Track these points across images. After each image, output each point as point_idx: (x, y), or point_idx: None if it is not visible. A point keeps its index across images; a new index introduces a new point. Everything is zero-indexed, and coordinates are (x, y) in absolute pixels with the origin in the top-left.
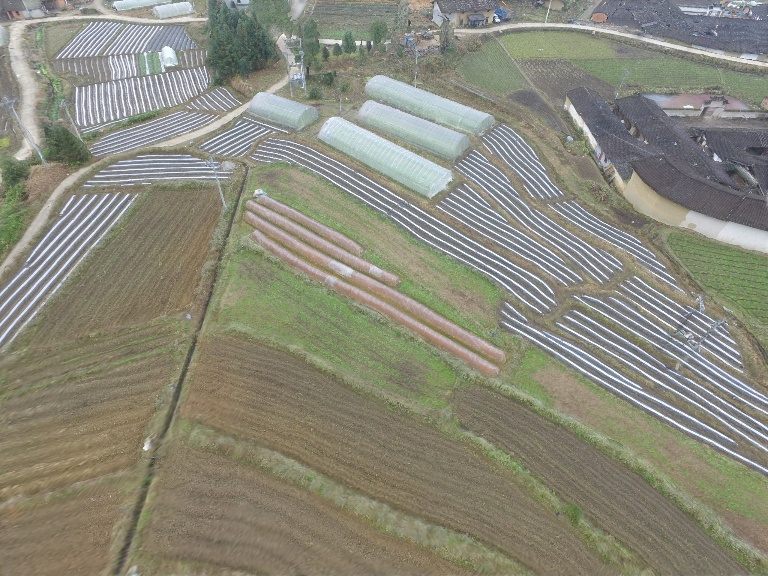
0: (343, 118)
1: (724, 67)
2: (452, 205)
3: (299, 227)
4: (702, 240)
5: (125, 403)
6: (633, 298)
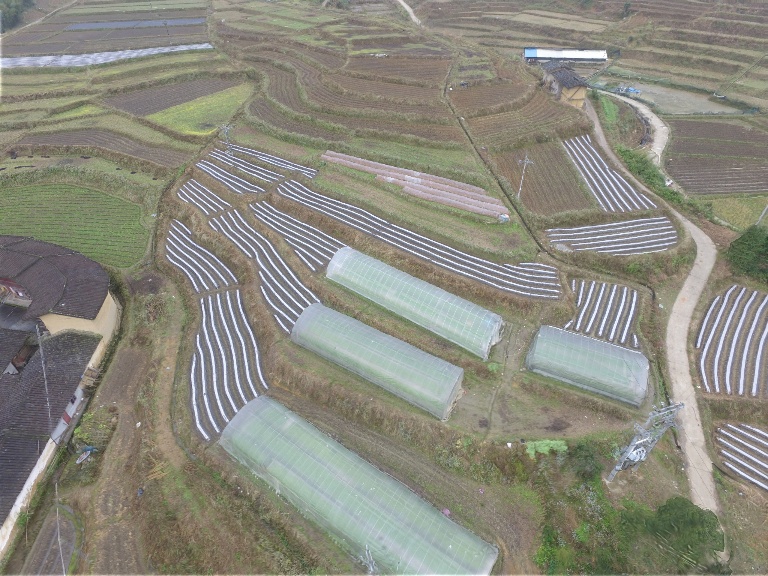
0: (492, 388)
1: None
2: (332, 249)
3: (454, 195)
4: (106, 263)
5: None
6: (220, 204)
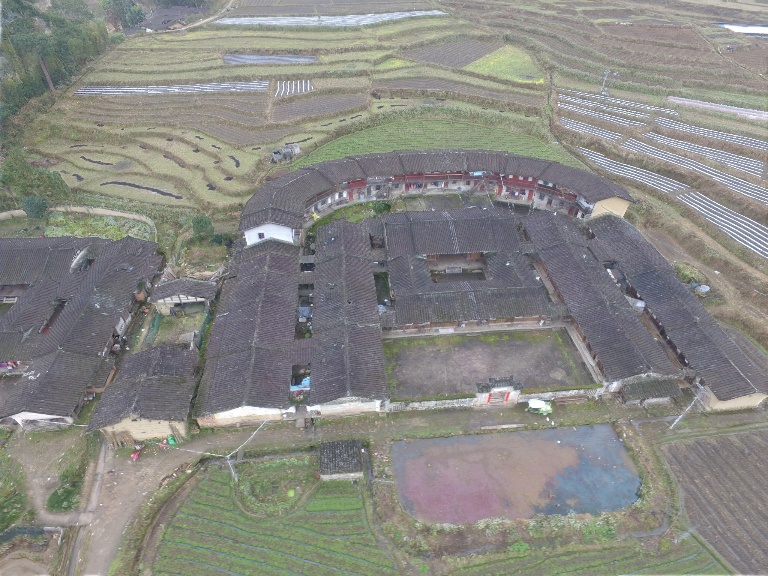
0: None
1: None
2: None
3: None
4: None
5: None
6: None
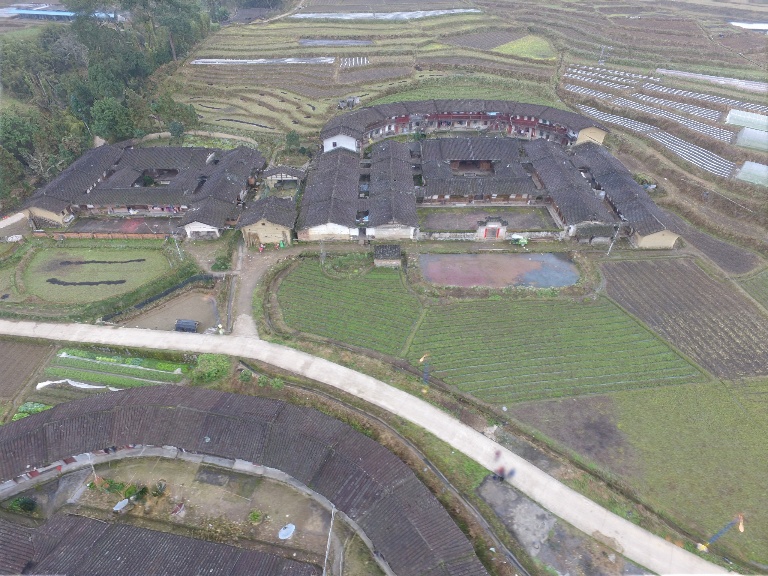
0: None
1: (390, 364)
2: None
3: None
4: None
5: (759, 59)
6: None
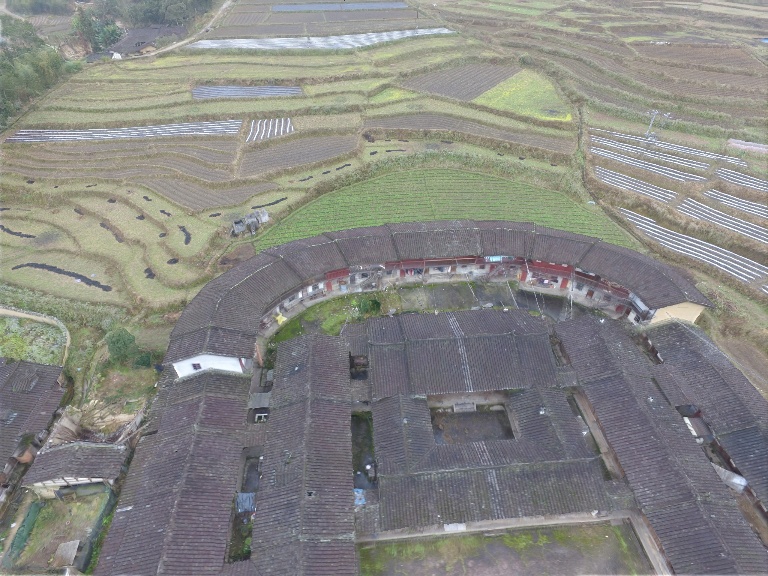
0: None
1: None
2: None
3: None
4: None
5: None
6: None
